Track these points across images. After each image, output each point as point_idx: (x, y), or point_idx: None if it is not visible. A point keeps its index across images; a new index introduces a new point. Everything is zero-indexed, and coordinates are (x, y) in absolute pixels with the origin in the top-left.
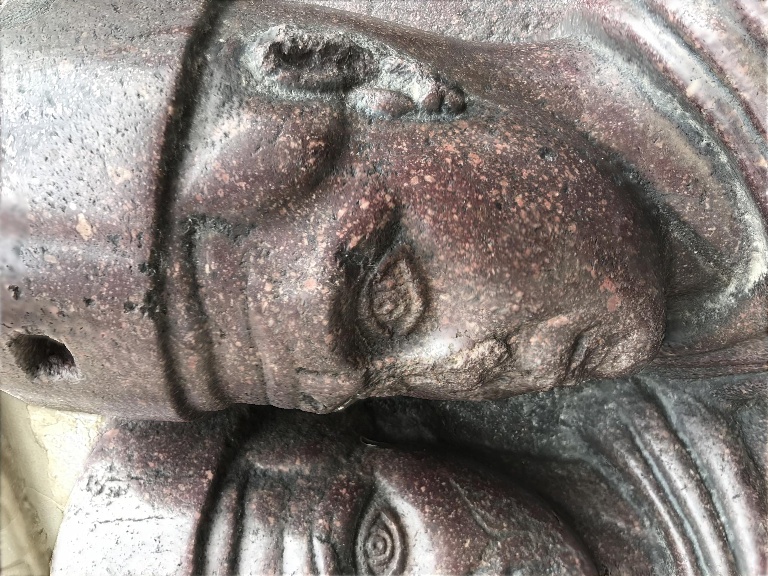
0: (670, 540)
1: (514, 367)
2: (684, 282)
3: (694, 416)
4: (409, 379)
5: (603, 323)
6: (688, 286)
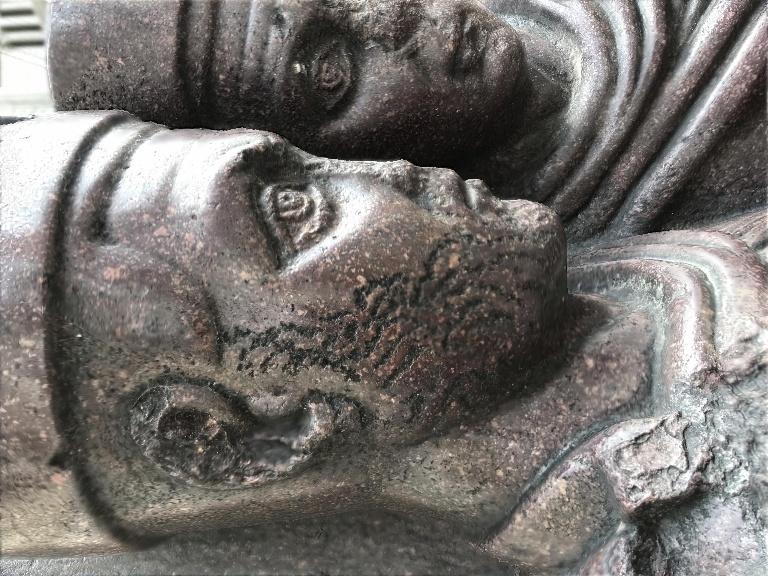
0: (624, 267)
1: (424, 14)
2: (541, 92)
3: (611, 241)
4: (353, 15)
5: (478, 12)
6: (545, 96)
